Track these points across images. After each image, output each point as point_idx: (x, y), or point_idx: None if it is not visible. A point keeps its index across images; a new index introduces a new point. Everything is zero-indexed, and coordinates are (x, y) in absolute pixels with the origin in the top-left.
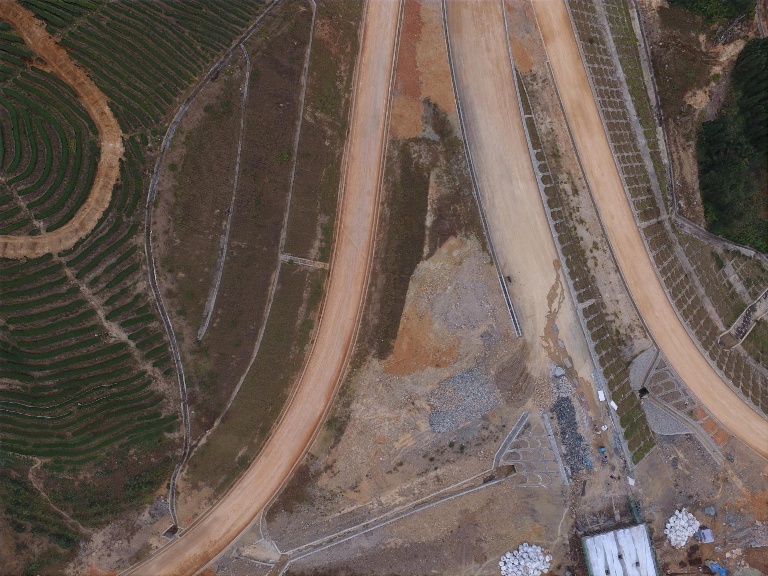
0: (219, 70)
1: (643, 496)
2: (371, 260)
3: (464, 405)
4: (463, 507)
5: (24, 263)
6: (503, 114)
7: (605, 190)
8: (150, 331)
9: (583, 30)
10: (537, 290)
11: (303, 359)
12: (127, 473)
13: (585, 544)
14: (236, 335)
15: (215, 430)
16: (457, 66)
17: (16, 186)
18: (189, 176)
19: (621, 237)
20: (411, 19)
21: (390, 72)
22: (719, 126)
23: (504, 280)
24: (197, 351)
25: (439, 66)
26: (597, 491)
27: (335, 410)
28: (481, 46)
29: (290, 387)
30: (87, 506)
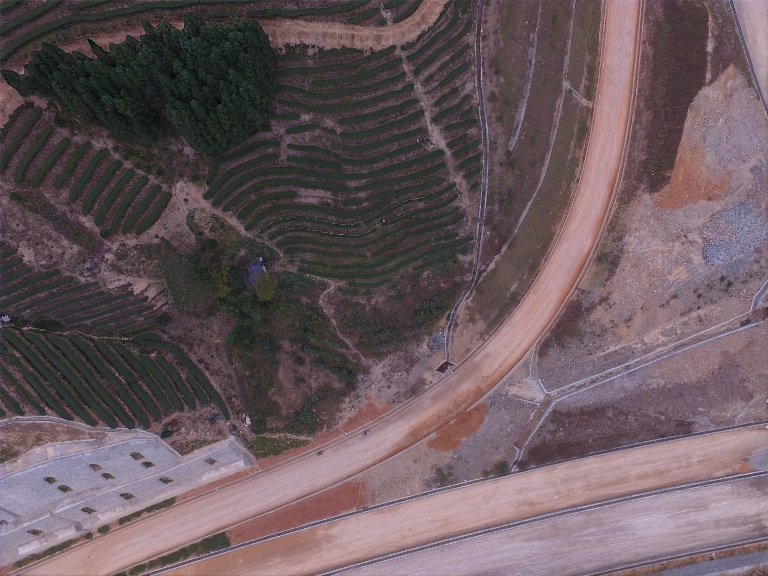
0: None
1: None
2: (634, 98)
3: (737, 237)
4: (723, 349)
5: (369, 55)
6: None
7: None
8: (468, 138)
9: None
10: None
11: (569, 197)
12: (418, 297)
13: None
14: (532, 154)
15: (503, 255)
16: None
17: None
18: None
19: None
20: None
21: None
22: None
23: None
24: (505, 163)
25: None
26: None
27: (604, 246)
28: None
29: (557, 224)
30: (374, 333)
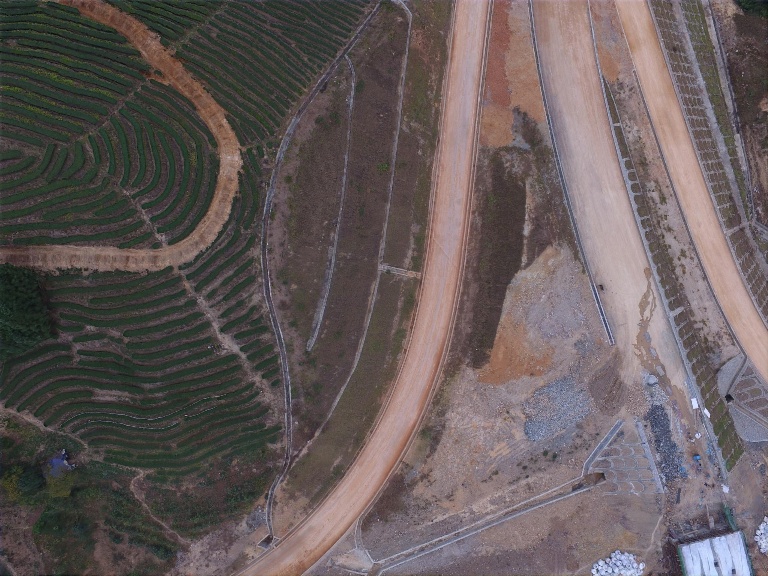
0: (327, 81)
1: (736, 503)
2: (463, 269)
3: (559, 414)
4: (553, 515)
5: (145, 276)
6: (592, 123)
7: (692, 198)
8: (262, 343)
9: (667, 38)
10: (629, 298)
11: (396, 368)
12: (229, 484)
13: (681, 552)
14: (340, 346)
15: (316, 440)
16: (545, 75)
17: (140, 200)
18: (302, 188)
19: (708, 245)
20: (499, 28)
21: (479, 81)
22: None
23: (596, 288)
24: (305, 362)
25: (528, 75)
26: (691, 499)
27: (429, 419)
28: (569, 55)
29: (383, 396)
30: (188, 517)
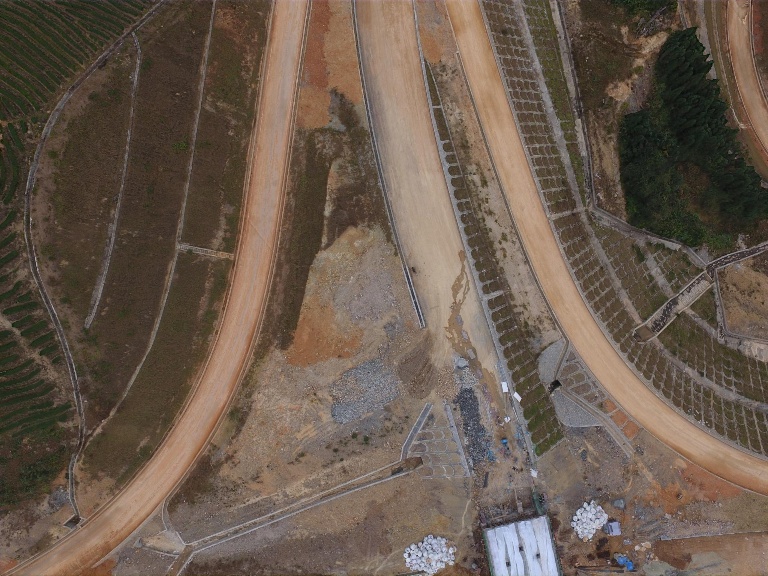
0: (107, 58)
1: (547, 488)
2: (276, 250)
3: (366, 396)
4: (370, 499)
5: None
6: (411, 105)
7: (515, 181)
8: (35, 319)
9: (495, 21)
10: (442, 281)
11: (207, 349)
12: (21, 462)
13: (486, 536)
14: (128, 324)
15: (111, 420)
16: (365, 56)
17: None
18: (72, 164)
19: (531, 228)
20: (319, 9)
21: (298, 62)
22: (638, 118)
23: (409, 271)
24: (85, 340)
25: (347, 56)
26: (499, 483)
27: (238, 401)
28: (390, 37)
29: (193, 377)
30: None
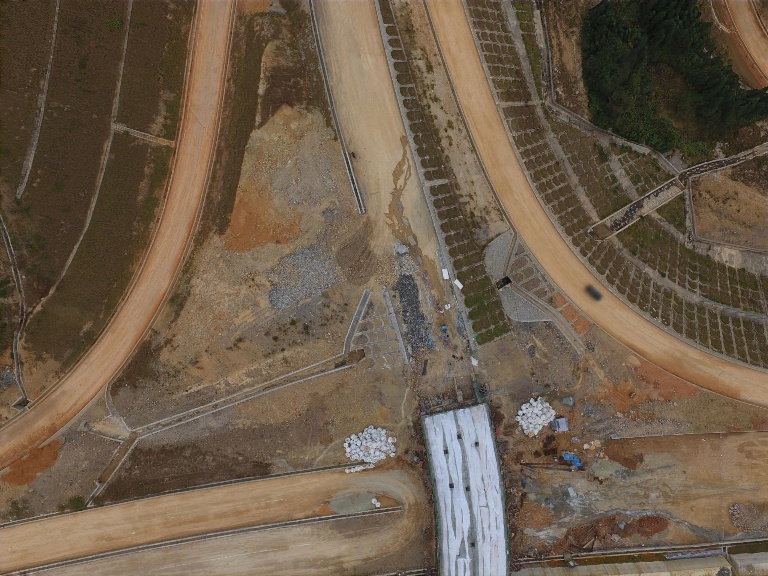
0: None
1: (488, 378)
2: (216, 138)
3: (303, 281)
4: (312, 390)
5: None
6: None
7: (463, 67)
8: None
9: None
10: (383, 167)
11: (148, 237)
12: None
13: (424, 423)
14: (63, 200)
15: (50, 298)
16: None
17: None
18: None
19: (479, 116)
20: None
21: None
22: (600, 7)
23: (349, 156)
24: (18, 211)
25: None
26: (439, 371)
27: (178, 287)
28: None
29: (135, 264)
30: None
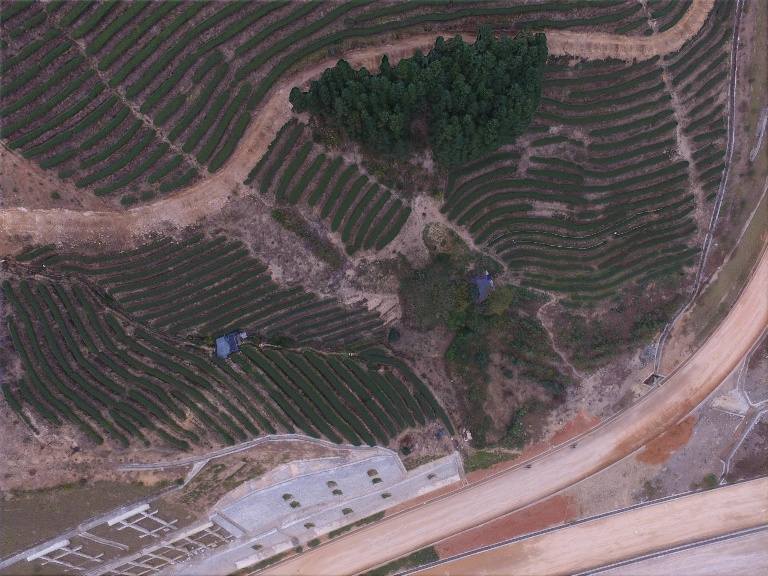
0: None
1: None
2: None
3: None
4: None
5: (632, 66)
6: None
7: None
8: (713, 149)
9: None
10: None
11: None
12: (640, 310)
13: None
14: (764, 164)
15: (725, 267)
16: None
17: None
18: None
19: None
20: None
21: None
22: None
23: None
24: None
25: None
26: None
27: None
28: None
29: (766, 233)
30: (591, 347)
